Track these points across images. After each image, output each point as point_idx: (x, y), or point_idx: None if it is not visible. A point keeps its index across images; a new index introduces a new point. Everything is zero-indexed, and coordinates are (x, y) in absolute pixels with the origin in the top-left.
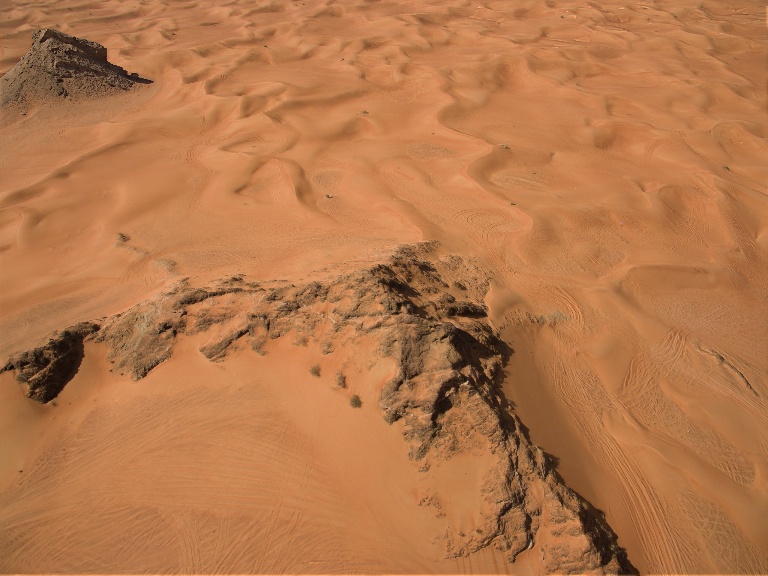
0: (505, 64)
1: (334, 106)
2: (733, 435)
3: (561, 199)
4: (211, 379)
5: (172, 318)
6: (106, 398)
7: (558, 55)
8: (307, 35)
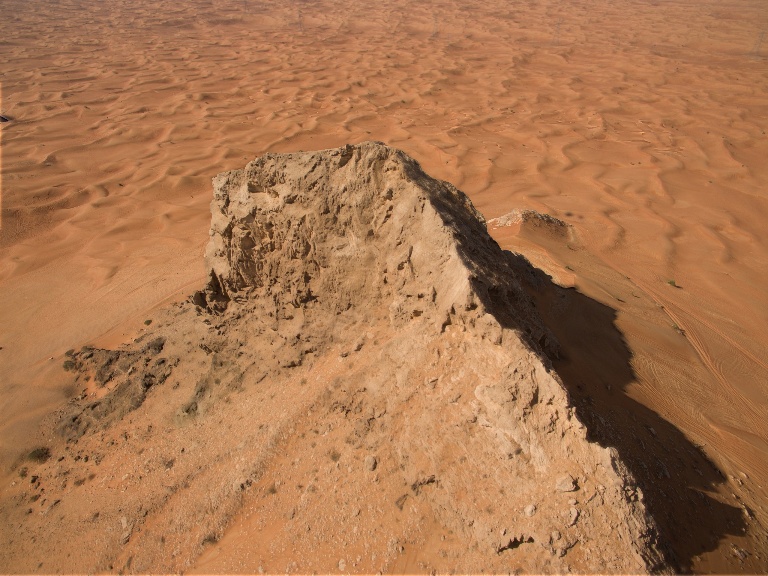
0: (164, 128)
1: (50, 141)
2: None
3: (2, 183)
4: None
5: None
6: None
7: (204, 126)
8: (129, 101)
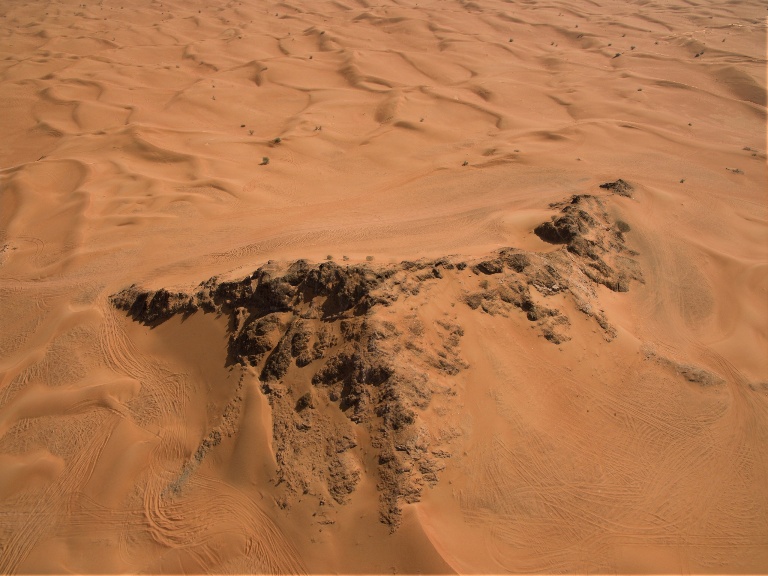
0: None
1: None
2: (2, 463)
3: None
4: (445, 252)
5: (514, 252)
6: (509, 244)
7: None
8: None
